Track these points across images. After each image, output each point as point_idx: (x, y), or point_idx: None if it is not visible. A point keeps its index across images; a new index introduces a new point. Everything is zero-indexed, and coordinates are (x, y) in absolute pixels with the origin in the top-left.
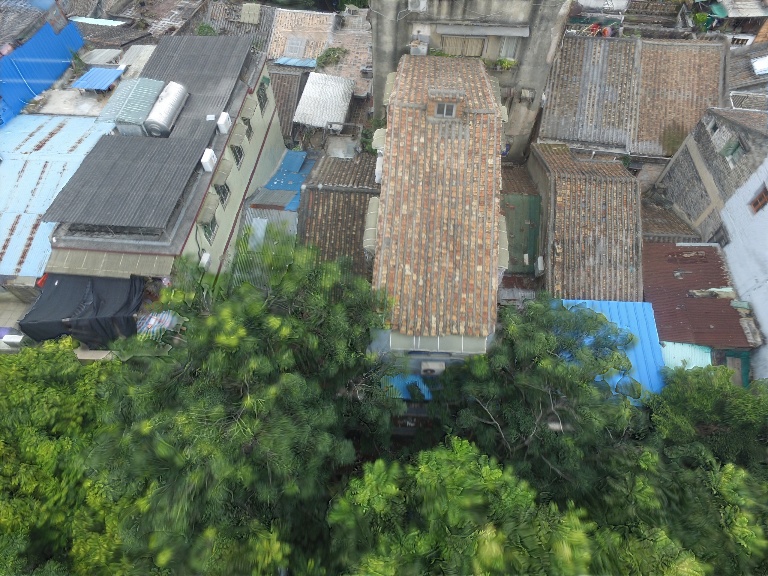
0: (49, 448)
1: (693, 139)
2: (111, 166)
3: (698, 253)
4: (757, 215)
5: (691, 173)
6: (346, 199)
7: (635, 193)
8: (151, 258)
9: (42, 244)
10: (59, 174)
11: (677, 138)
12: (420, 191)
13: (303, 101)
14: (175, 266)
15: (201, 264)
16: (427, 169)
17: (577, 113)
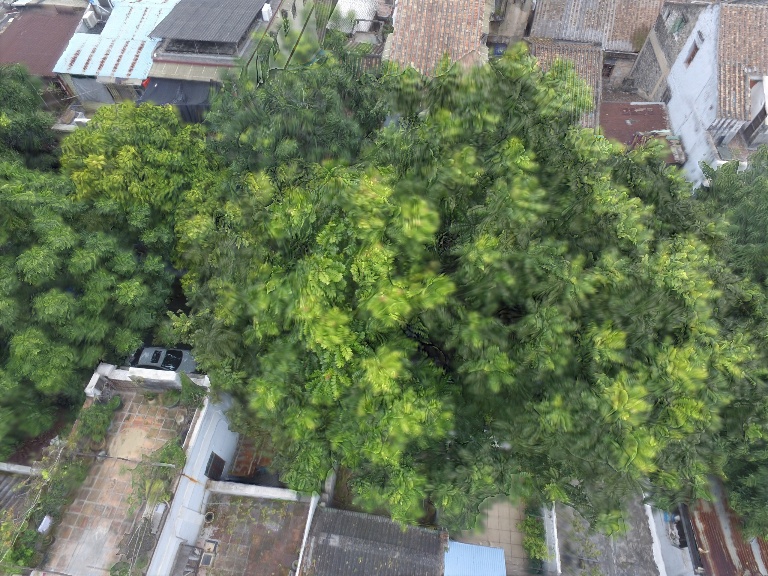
0: (164, 156)
1: (654, 30)
2: (195, 10)
3: (647, 109)
4: (689, 67)
5: (651, 58)
6: (369, 62)
7: (598, 59)
8: (225, 69)
9: (146, 59)
10: (156, 16)
11: (645, 38)
12: (425, 15)
13: (335, 14)
14: (242, 77)
15: None
16: (431, 1)
17: (563, 17)
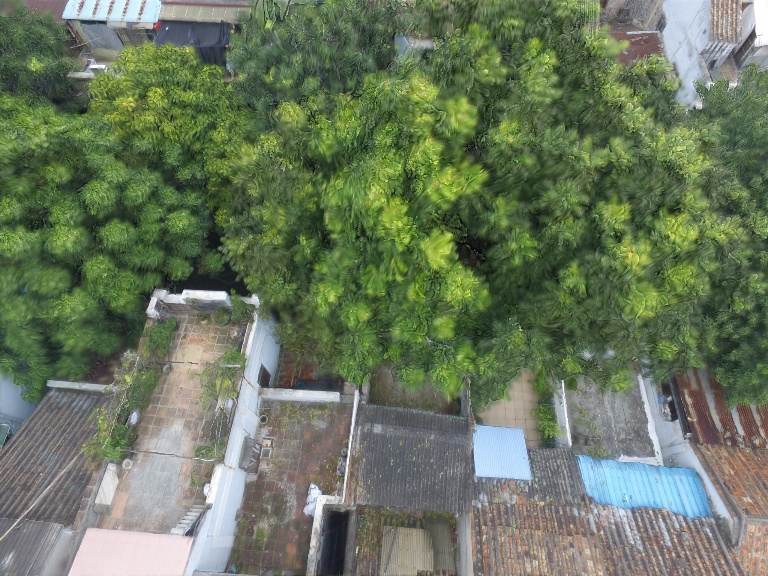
0: (189, 96)
1: None
2: None
3: (643, 38)
4: None
5: None
6: None
7: None
8: (234, 9)
9: (154, 2)
10: None
11: None
12: None
13: None
14: (251, 17)
15: (267, 25)
16: None
17: None
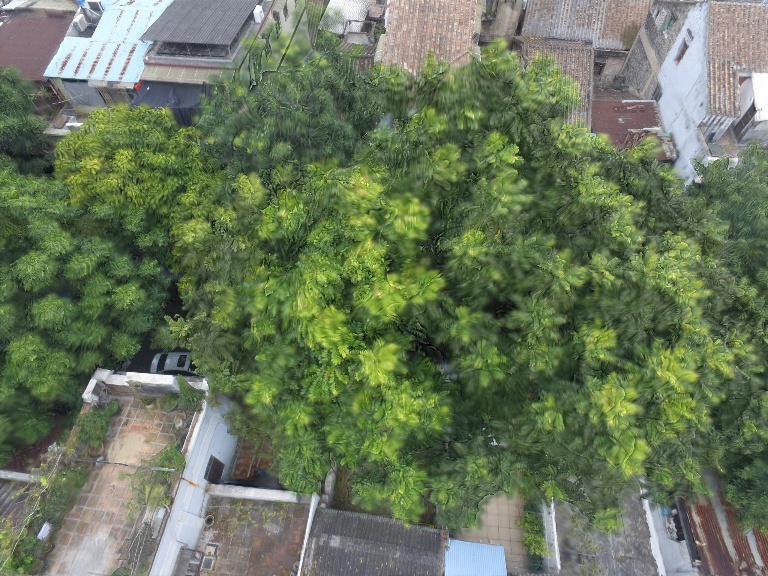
0: (157, 160)
1: (644, 28)
2: (187, 12)
3: (638, 106)
4: (679, 64)
5: (641, 56)
6: (361, 63)
7: (589, 58)
8: (218, 71)
9: (137, 62)
10: (147, 19)
11: (635, 36)
12: (417, 16)
13: (326, 15)
14: (235, 79)
15: None
16: (422, 2)
17: (554, 16)
